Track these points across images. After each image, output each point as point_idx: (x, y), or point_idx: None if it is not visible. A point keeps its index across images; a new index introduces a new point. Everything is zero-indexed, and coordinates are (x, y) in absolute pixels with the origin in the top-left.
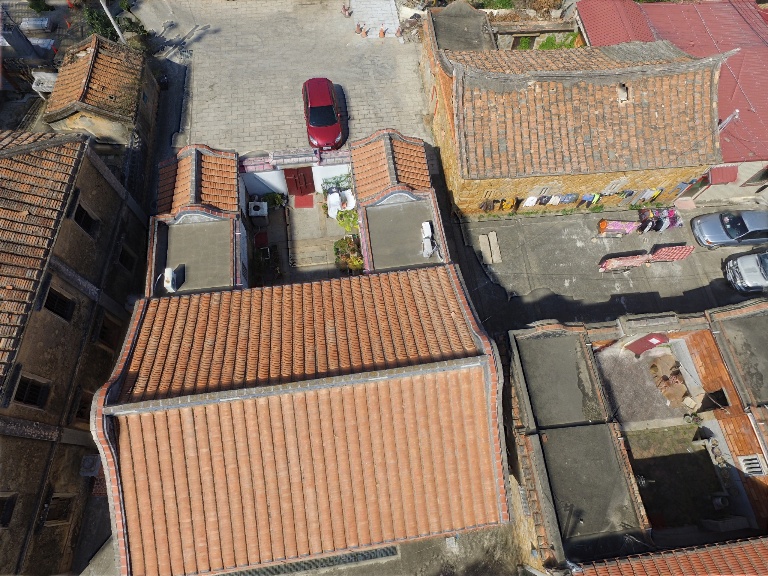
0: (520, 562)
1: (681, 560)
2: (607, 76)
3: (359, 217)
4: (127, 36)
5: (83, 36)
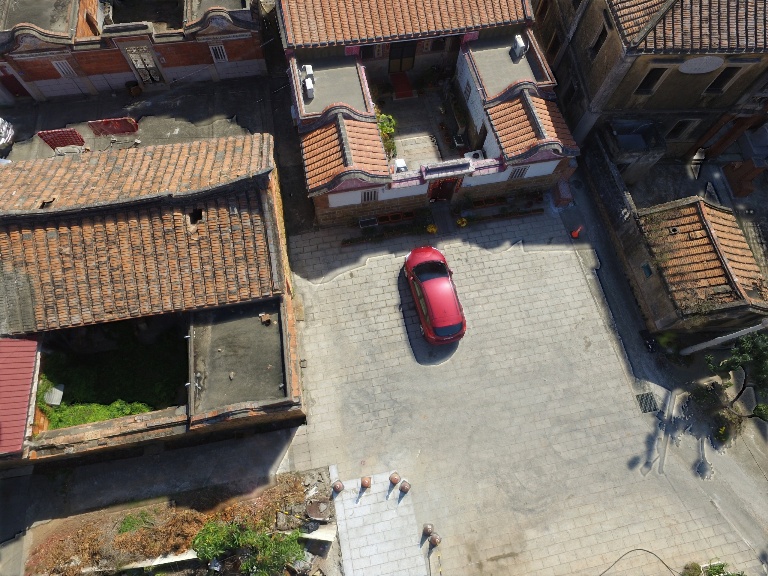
0: None
1: None
2: None
3: None
4: (748, 434)
5: None
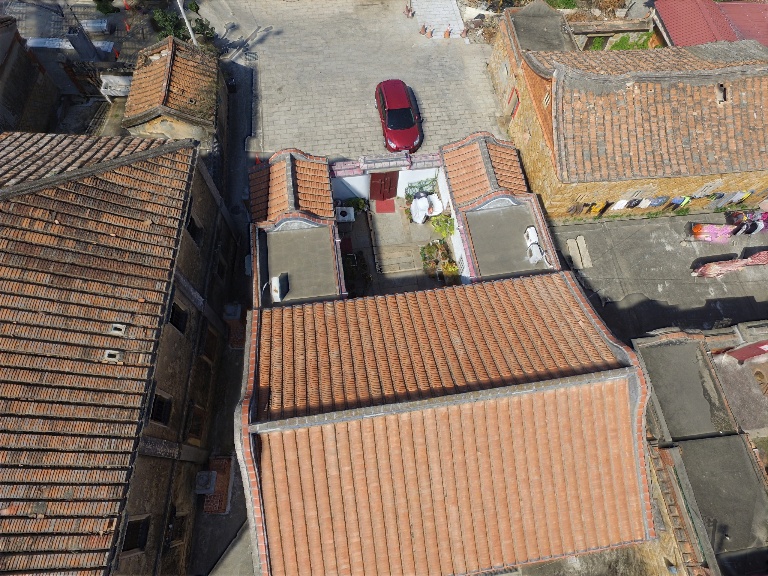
0: None
1: None
2: (706, 76)
3: (459, 222)
4: None
5: (144, 38)
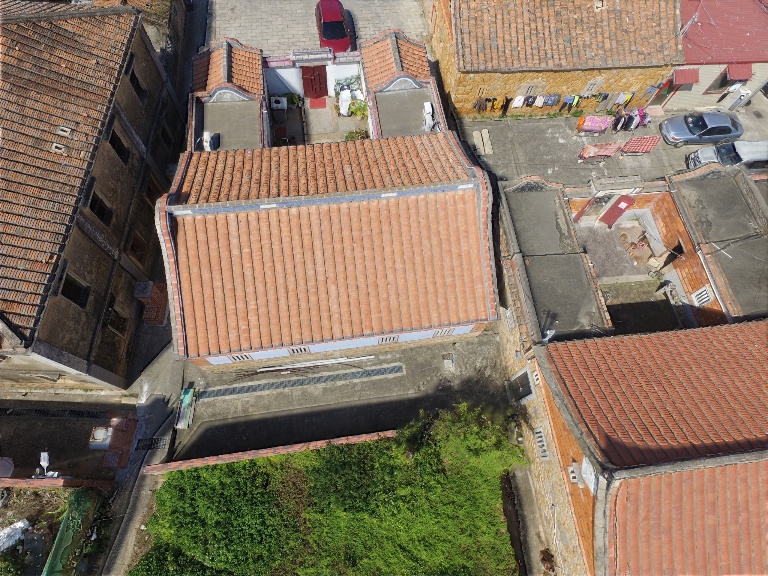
0: (507, 378)
1: (636, 340)
2: None
3: (369, 101)
4: None
5: None
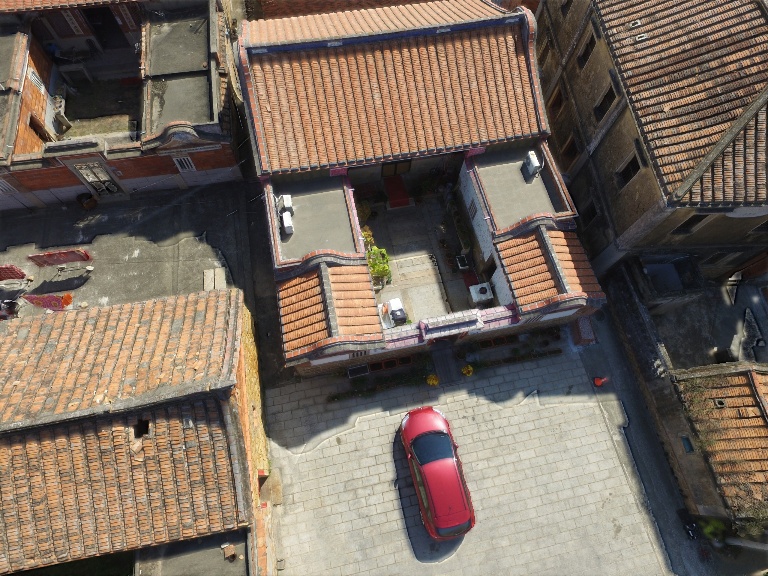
0: None
1: None
2: None
3: (363, 244)
4: None
5: None
